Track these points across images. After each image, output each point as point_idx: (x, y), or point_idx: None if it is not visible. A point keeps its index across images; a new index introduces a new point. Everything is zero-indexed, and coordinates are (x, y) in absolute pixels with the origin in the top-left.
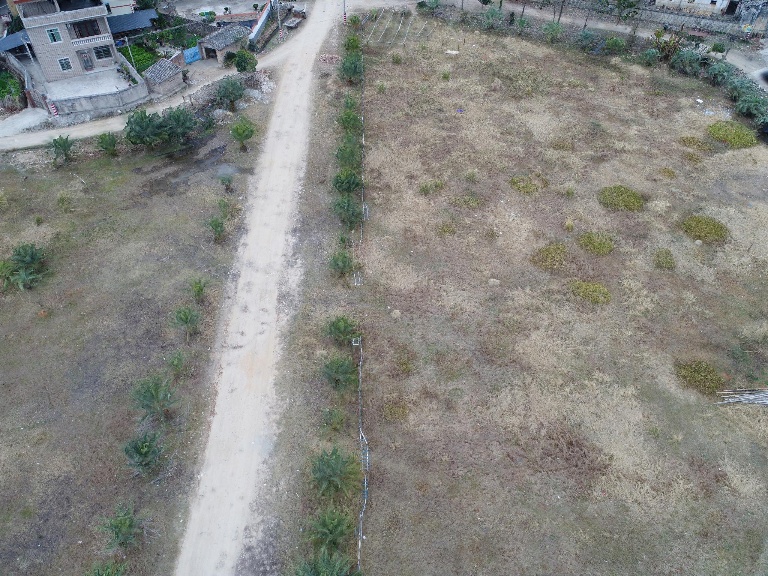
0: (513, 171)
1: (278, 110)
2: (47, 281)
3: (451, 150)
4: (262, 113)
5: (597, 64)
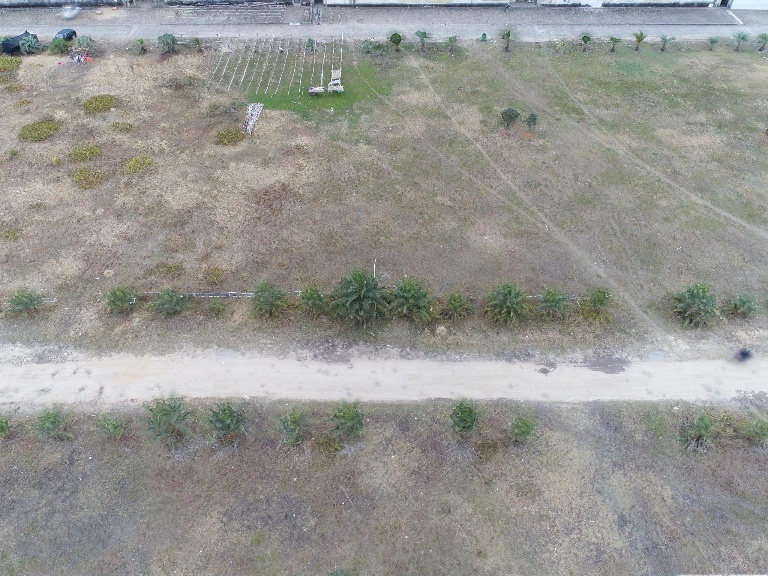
0: None
1: None
2: None
3: None
4: None
5: None
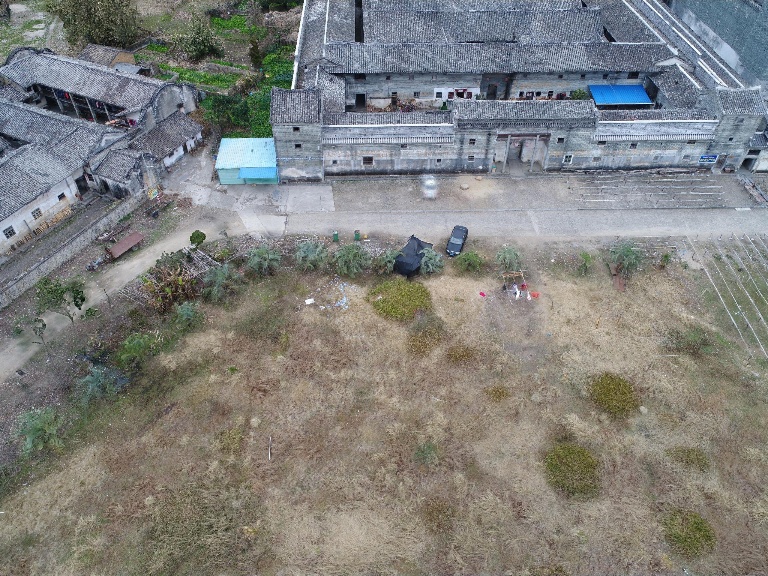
0: None
1: None
2: None
3: None
4: None
5: (167, 390)
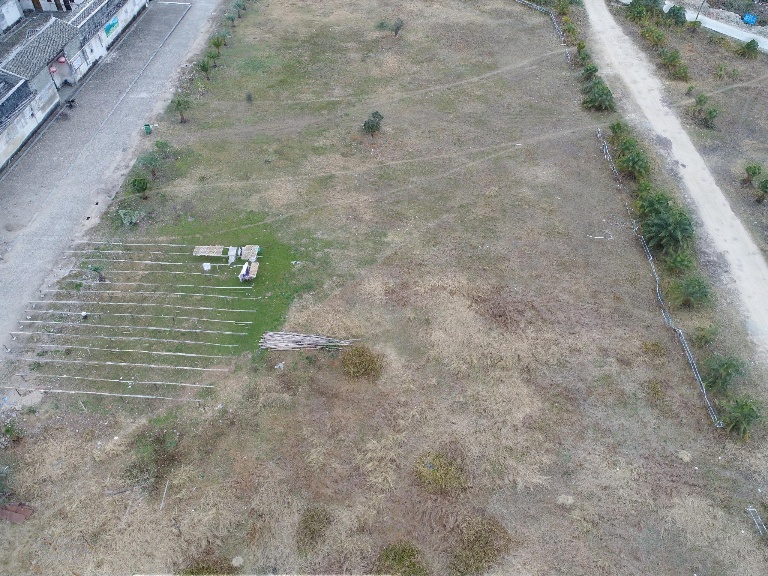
0: None
1: None
2: None
3: None
4: None
5: None
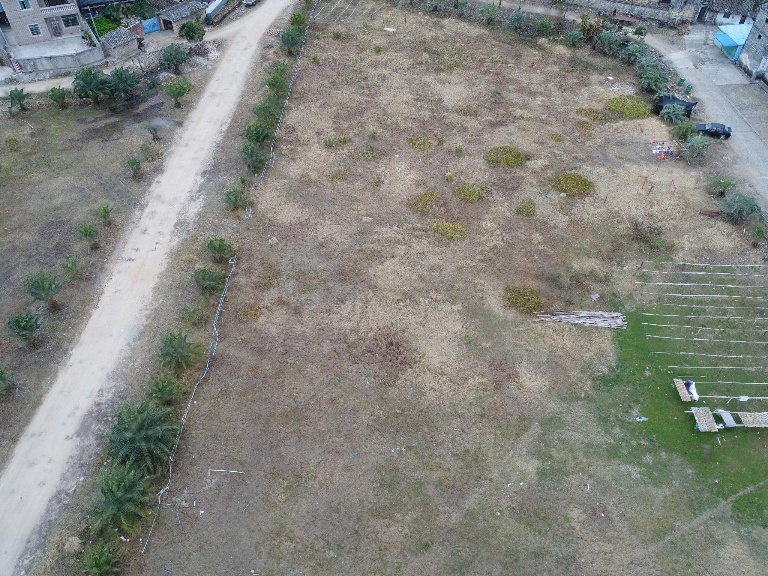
0: (414, 131)
1: (218, 75)
2: None
3: (364, 112)
4: (203, 77)
5: (525, 44)
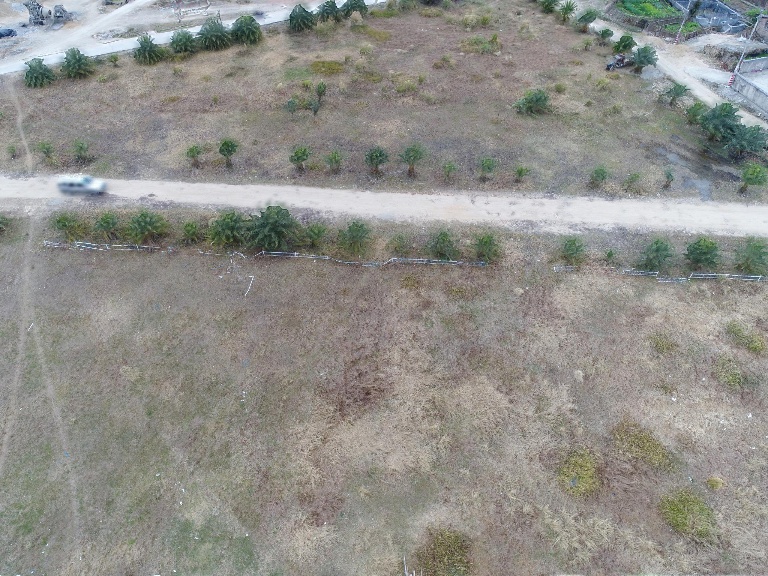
0: None
1: None
2: (527, 118)
3: None
4: None
5: None
